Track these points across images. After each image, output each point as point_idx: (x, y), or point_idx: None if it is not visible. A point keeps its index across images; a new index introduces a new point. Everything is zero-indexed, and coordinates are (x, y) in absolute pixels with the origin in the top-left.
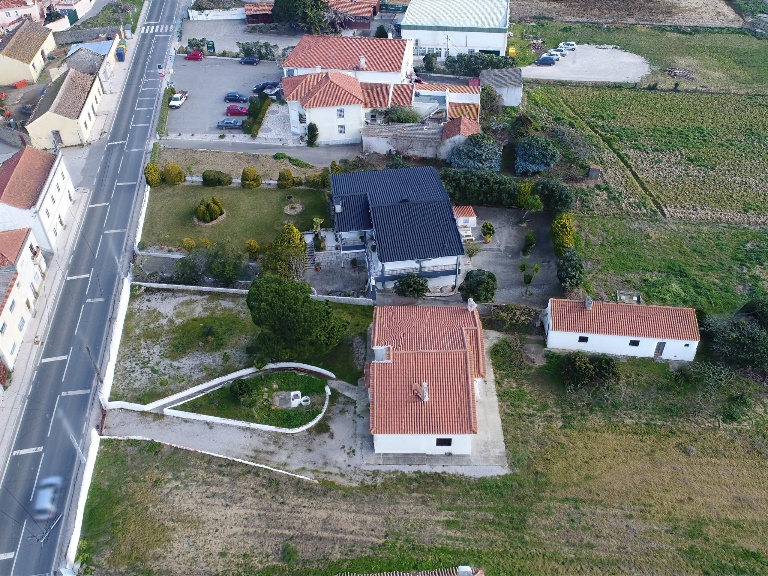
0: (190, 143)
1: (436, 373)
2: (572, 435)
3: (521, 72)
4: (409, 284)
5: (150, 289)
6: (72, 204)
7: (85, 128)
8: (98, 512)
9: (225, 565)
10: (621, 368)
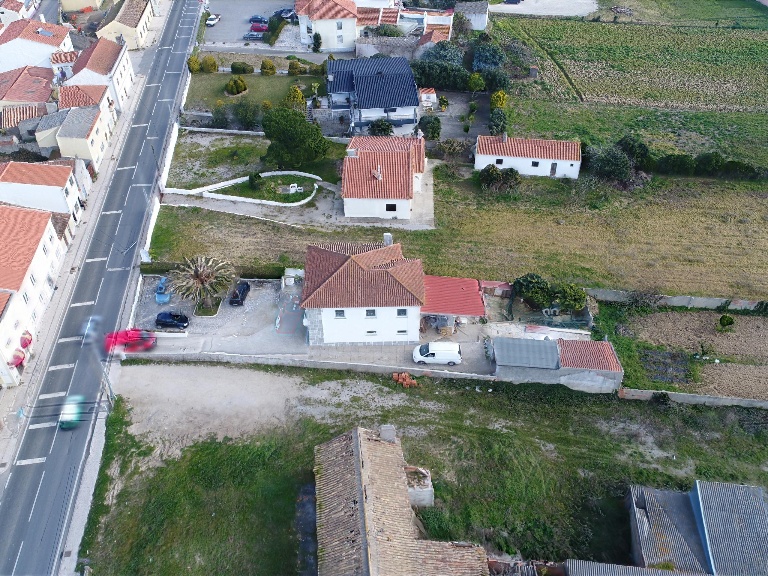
0: (222, 48)
1: (388, 164)
2: (482, 213)
3: (488, 4)
4: (378, 125)
5: (192, 132)
6: (133, 84)
7: (141, 37)
8: (161, 237)
9: (243, 262)
10: (525, 181)
